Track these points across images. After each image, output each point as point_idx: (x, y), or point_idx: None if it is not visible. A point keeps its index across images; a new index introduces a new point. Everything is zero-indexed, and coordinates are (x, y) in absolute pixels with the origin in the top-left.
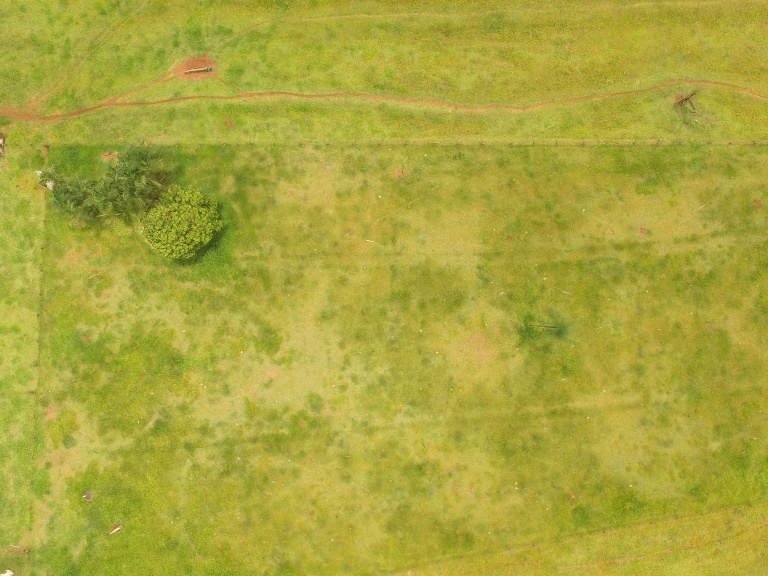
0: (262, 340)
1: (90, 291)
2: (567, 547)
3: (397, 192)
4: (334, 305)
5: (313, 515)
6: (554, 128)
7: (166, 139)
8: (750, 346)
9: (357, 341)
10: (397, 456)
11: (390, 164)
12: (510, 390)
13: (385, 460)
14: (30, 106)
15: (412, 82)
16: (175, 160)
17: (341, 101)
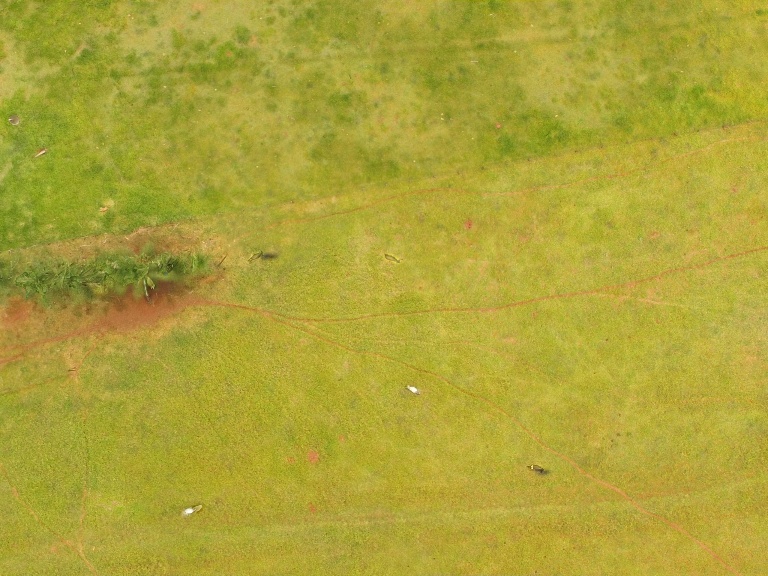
0: None
1: None
2: (492, 174)
3: None
4: None
5: (238, 142)
6: None
7: None
8: None
9: None
10: (323, 86)
11: None
12: (437, 24)
13: (311, 90)
14: None
15: None
16: None
17: None
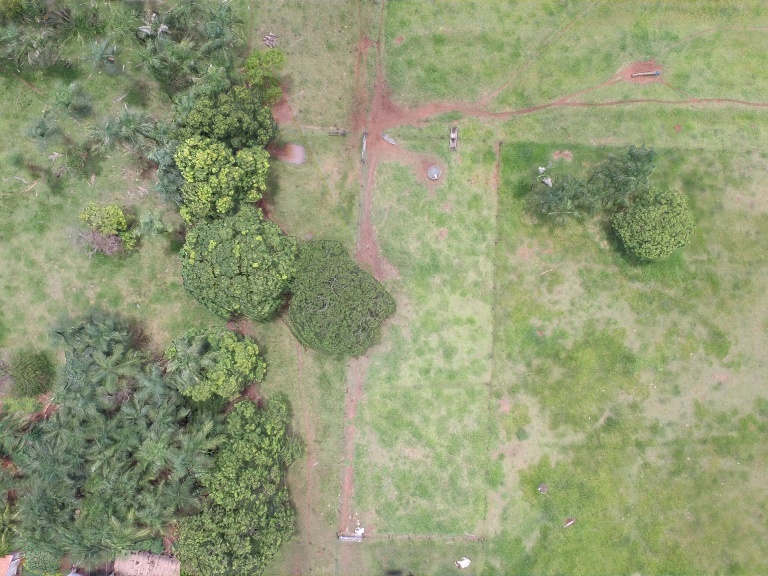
0: (713, 343)
1: (542, 287)
2: None
3: None
4: None
5: (762, 518)
6: None
7: (615, 141)
8: None
9: None
10: None
11: None
12: None
13: None
14: (482, 102)
15: None
16: None
17: None
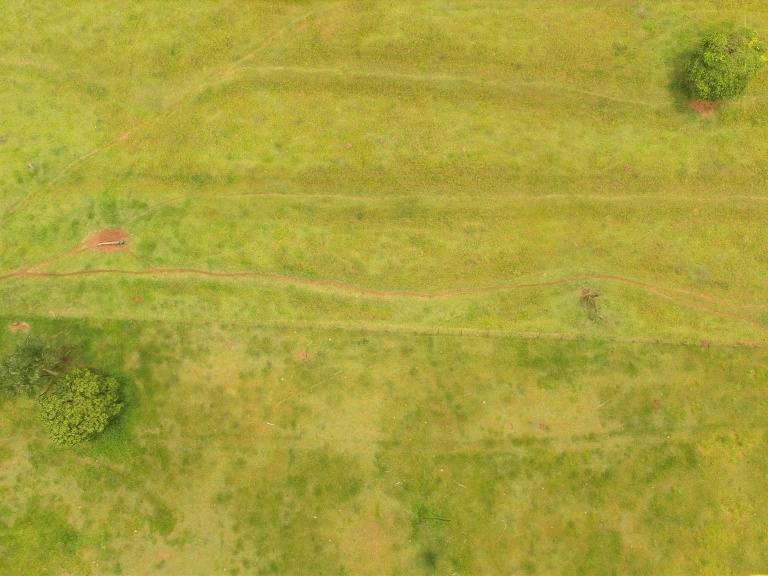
0: (156, 520)
1: None
2: None
3: (300, 375)
4: (230, 487)
5: None
6: (460, 317)
7: (74, 311)
8: (642, 549)
9: (251, 525)
10: None
11: (294, 347)
12: None
13: None
14: None
15: (321, 264)
16: (81, 334)
17: (250, 281)
